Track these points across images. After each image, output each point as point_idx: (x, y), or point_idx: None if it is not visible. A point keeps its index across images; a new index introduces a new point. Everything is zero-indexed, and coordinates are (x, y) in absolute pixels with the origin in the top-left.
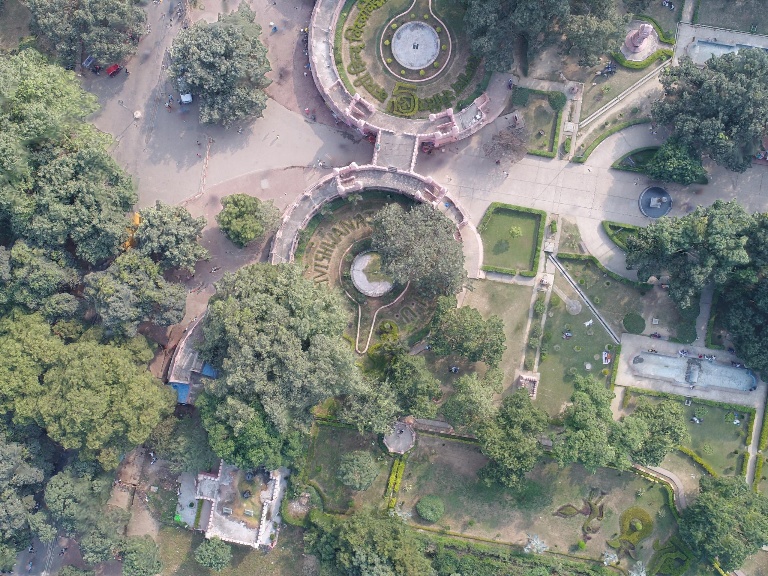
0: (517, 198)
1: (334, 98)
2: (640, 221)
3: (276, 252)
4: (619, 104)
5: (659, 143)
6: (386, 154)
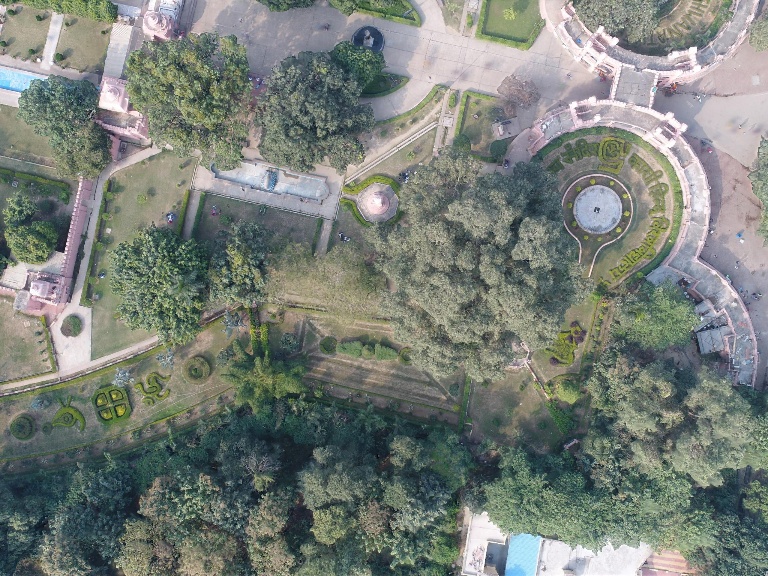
0: (504, 54)
1: (688, 154)
2: (384, 26)
3: (754, 2)
4: (398, 143)
5: (362, 102)
6: (645, 85)
